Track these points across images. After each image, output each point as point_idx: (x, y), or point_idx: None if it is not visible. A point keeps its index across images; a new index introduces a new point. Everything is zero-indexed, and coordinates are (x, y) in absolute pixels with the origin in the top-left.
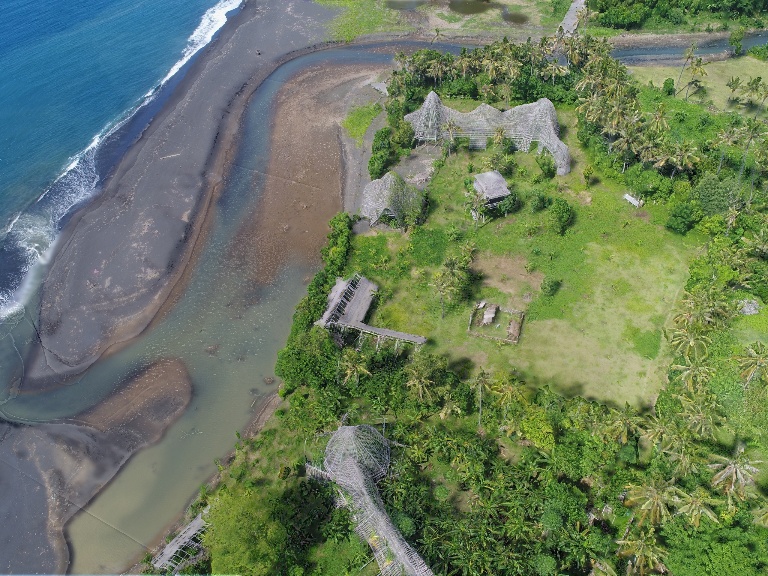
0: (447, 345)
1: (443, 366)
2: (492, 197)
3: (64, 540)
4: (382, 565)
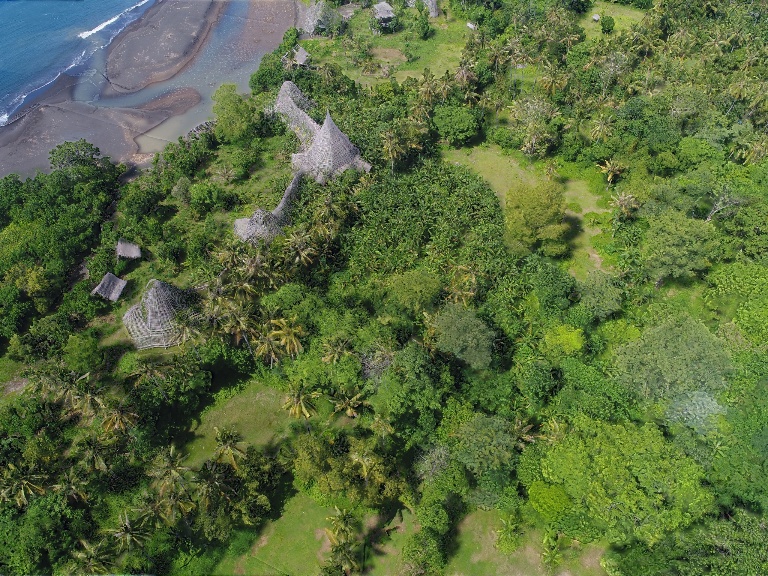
0: None
1: (340, 68)
2: (383, 17)
3: (134, 142)
4: (301, 137)
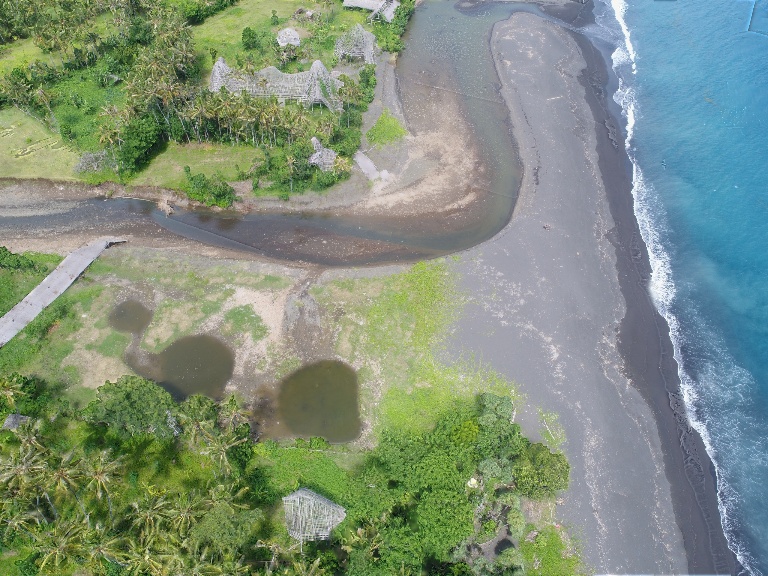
0: (333, 12)
1: None
2: None
3: None
4: None
